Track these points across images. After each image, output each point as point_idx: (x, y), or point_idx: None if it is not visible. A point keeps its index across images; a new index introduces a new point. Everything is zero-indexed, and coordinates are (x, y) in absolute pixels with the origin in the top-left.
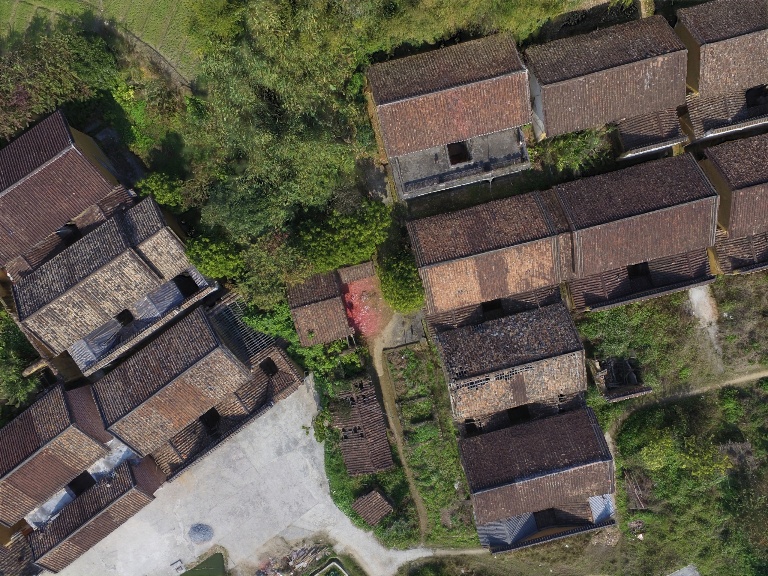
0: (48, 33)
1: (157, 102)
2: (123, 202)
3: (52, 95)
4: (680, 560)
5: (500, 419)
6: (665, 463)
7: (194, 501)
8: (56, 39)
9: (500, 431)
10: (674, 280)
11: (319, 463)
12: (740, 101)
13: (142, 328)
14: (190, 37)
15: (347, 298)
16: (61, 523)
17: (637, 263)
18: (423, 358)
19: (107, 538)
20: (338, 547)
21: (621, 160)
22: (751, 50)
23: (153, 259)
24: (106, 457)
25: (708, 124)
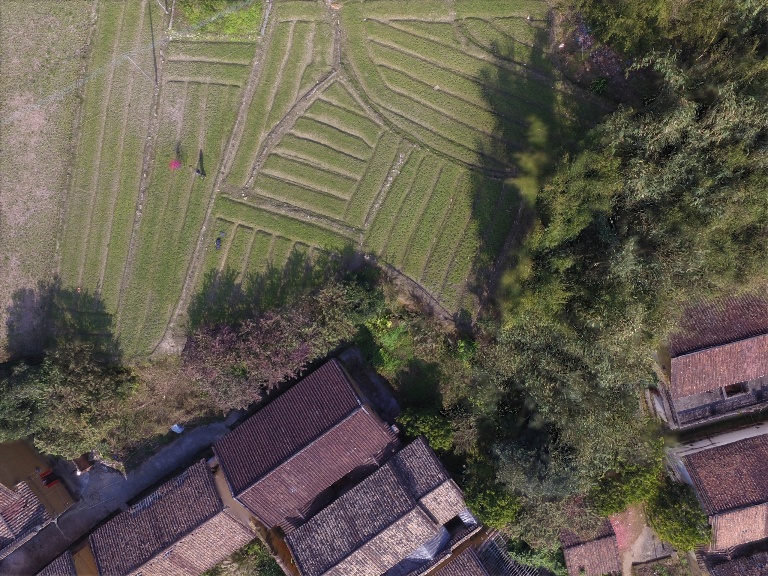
0: (306, 268)
1: (428, 343)
2: (390, 442)
3: (326, 344)
4: None
5: None
6: None
7: None
8: (333, 290)
9: None
10: None
11: None
12: None
13: (413, 571)
14: (452, 269)
15: None
16: None
17: None
18: (676, 573)
19: None
20: None
21: None
22: None
23: (431, 508)
24: None
25: None
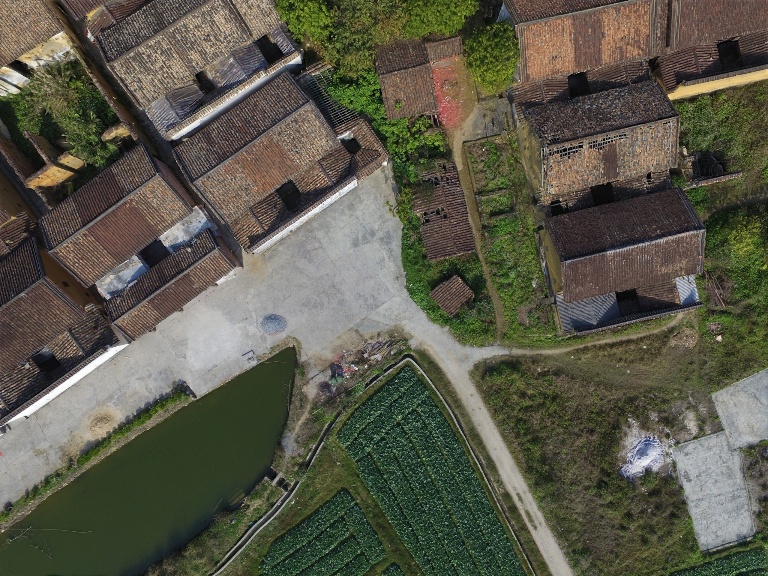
0: None
1: None
2: None
3: None
4: (759, 362)
5: (586, 203)
6: (746, 263)
7: (268, 291)
8: None
9: (588, 209)
10: (767, 60)
11: (396, 255)
12: None
13: (227, 90)
14: None
15: None
16: (139, 288)
17: (732, 37)
18: (504, 151)
19: (178, 326)
20: (413, 342)
21: None
22: None
23: (243, 12)
24: (186, 225)
25: None
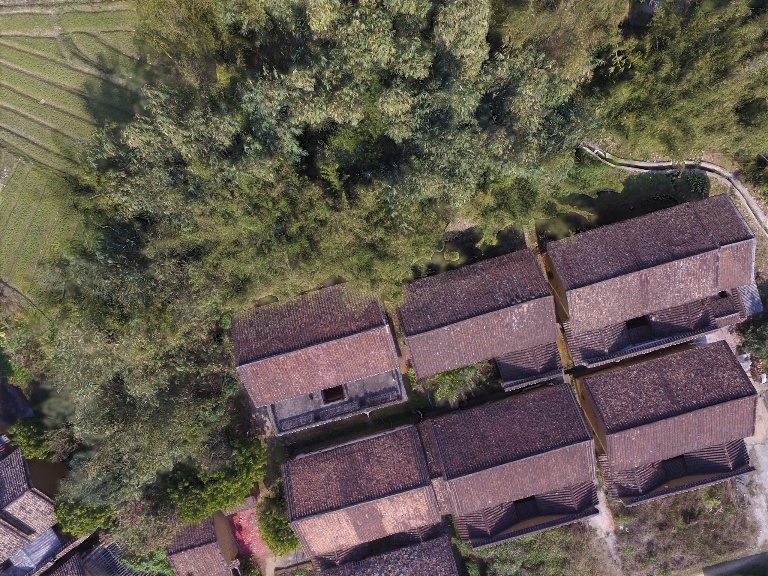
0: None
1: (22, 355)
2: None
3: None
4: None
5: None
6: None
7: None
8: None
9: None
10: (559, 510)
11: None
12: (619, 327)
13: None
14: (57, 281)
15: (235, 520)
16: None
17: (517, 499)
18: None
19: None
20: None
21: None
22: (620, 290)
23: (22, 517)
24: None
25: (586, 353)
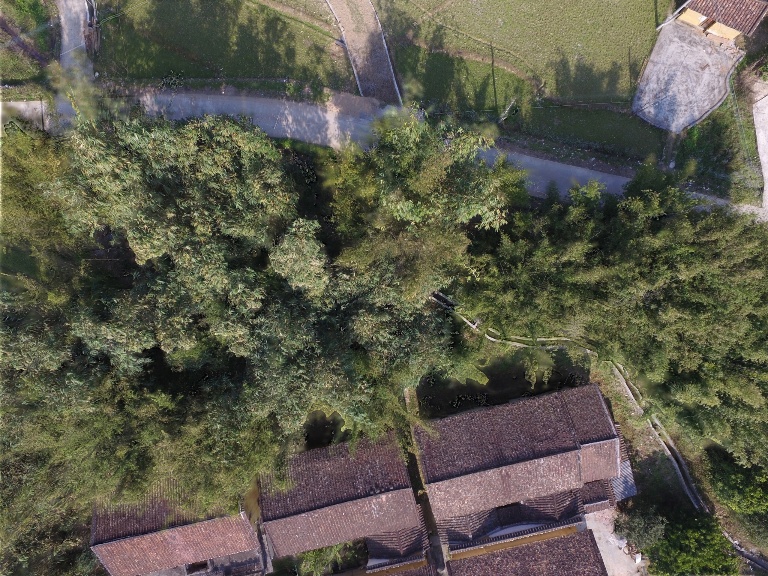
0: None
1: None
2: None
3: None
4: None
5: None
6: None
7: None
8: None
9: None
10: None
11: None
12: (487, 509)
13: None
14: None
15: None
16: None
17: None
18: None
19: None
20: None
21: None
22: (480, 483)
23: None
24: None
25: (452, 535)
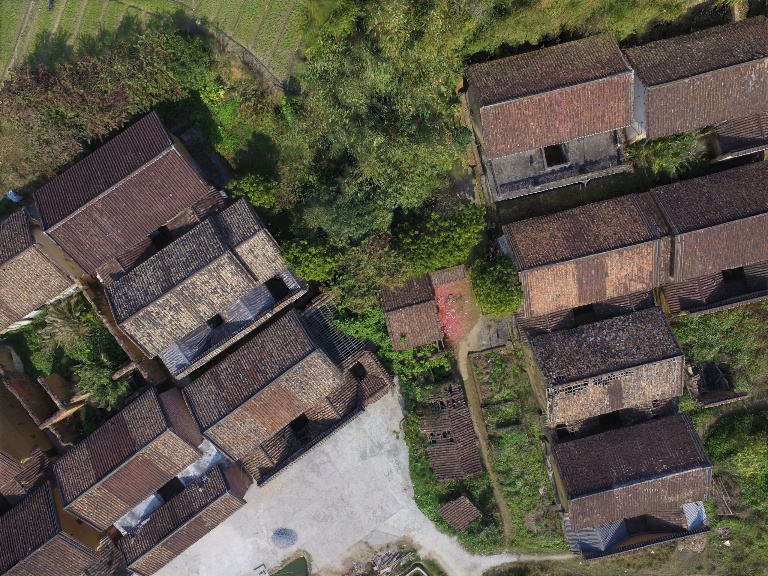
0: (139, 32)
1: (252, 102)
2: (215, 204)
3: (147, 95)
4: (767, 567)
5: (591, 424)
6: None
7: (277, 505)
8: (153, 38)
9: (594, 436)
10: None
11: (404, 467)
12: None
13: (234, 331)
14: (283, 37)
15: None
16: (152, 528)
17: (736, 267)
18: (509, 362)
19: None
20: (422, 552)
21: (715, 163)
22: None
23: (249, 262)
24: (196, 461)
25: None
